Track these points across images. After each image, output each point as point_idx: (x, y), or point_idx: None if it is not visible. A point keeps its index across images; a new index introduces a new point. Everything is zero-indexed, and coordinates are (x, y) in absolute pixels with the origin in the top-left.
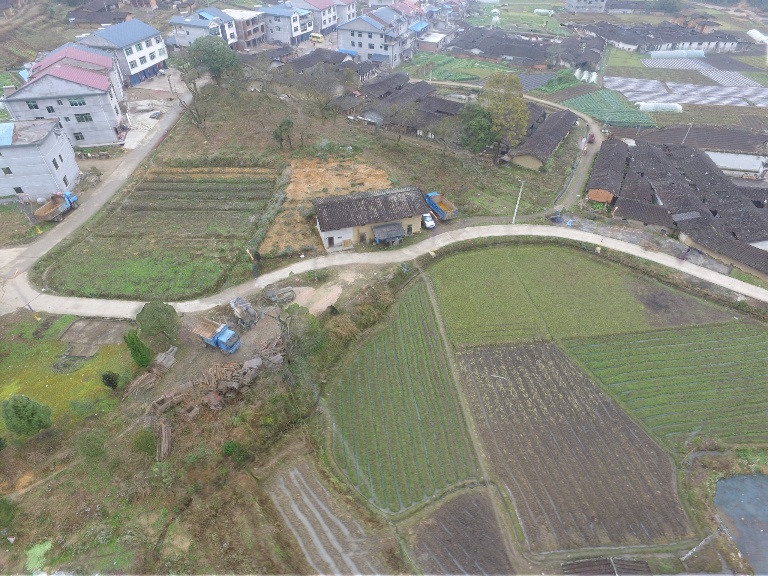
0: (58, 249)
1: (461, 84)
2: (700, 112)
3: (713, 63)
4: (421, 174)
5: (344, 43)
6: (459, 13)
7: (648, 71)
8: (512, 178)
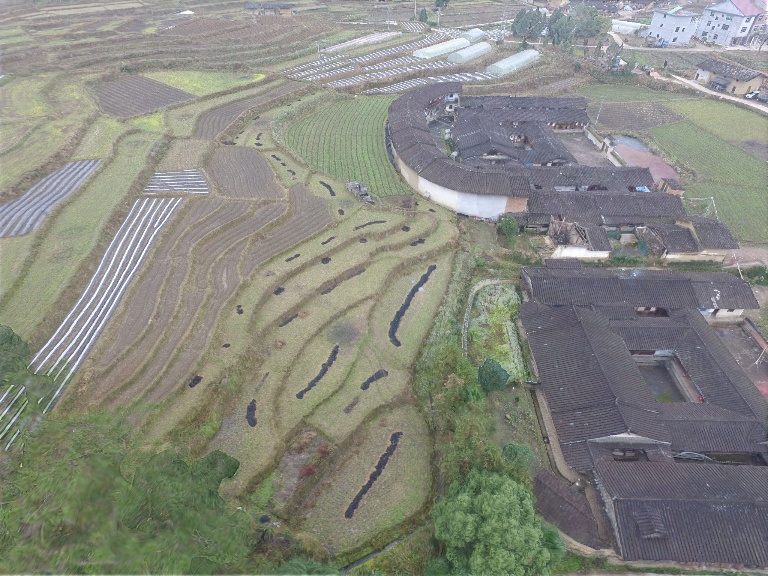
0: (635, 50)
1: None
2: None
3: None
4: None
5: None
6: None
7: None
8: None
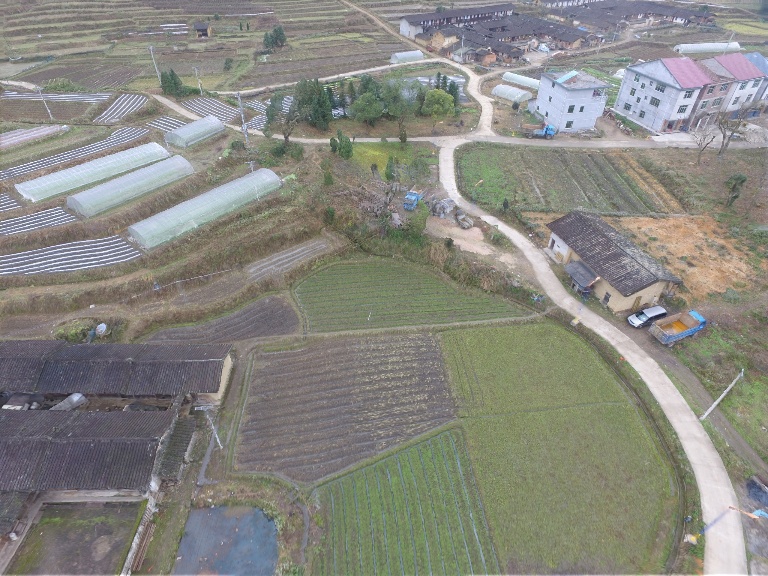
0: (499, 144)
1: None
2: None
3: None
4: None
5: None
6: None
7: None
8: None
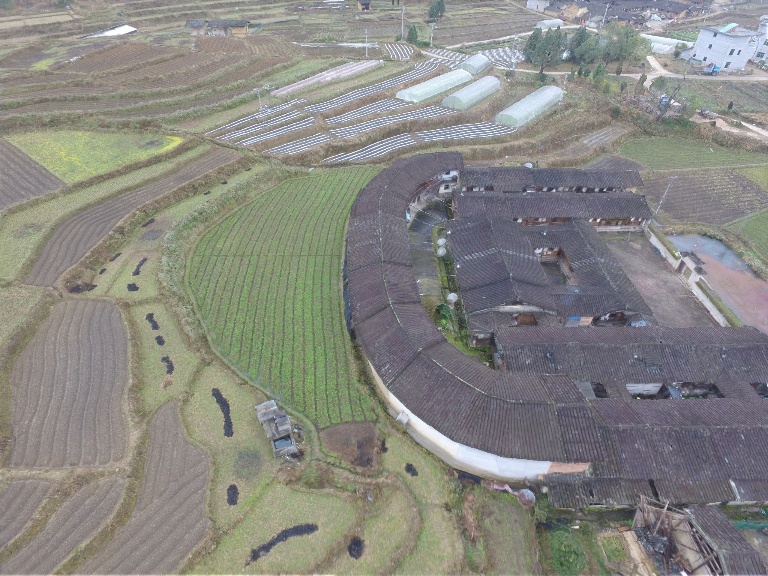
0: (680, 79)
1: None
2: None
3: None
4: None
5: None
6: None
7: None
8: None
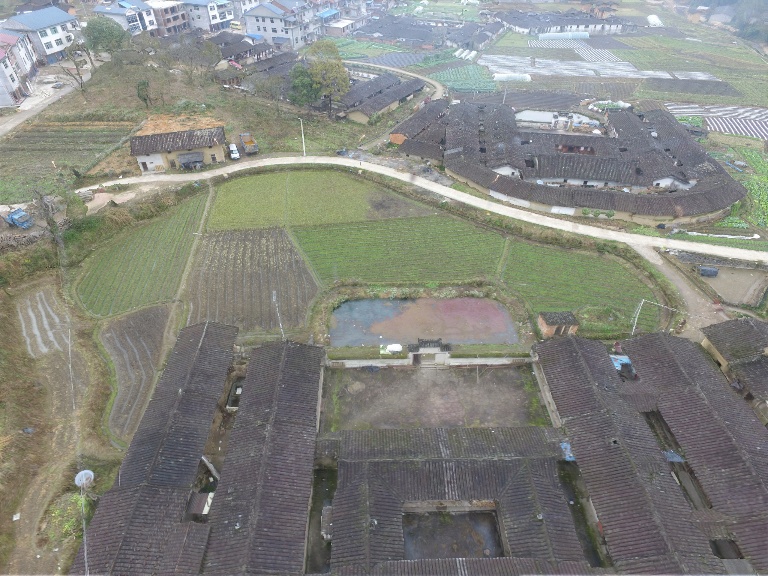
0: None
1: (344, 61)
2: (545, 81)
3: (593, 43)
4: (255, 124)
5: (251, 28)
6: (382, 3)
7: (527, 50)
8: (338, 129)
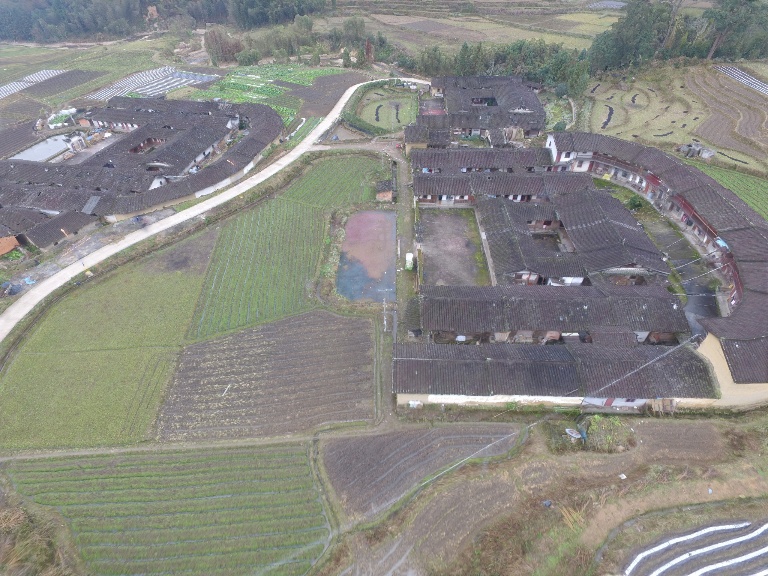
0: None
1: None
2: None
3: None
4: None
5: None
6: None
7: None
8: None
